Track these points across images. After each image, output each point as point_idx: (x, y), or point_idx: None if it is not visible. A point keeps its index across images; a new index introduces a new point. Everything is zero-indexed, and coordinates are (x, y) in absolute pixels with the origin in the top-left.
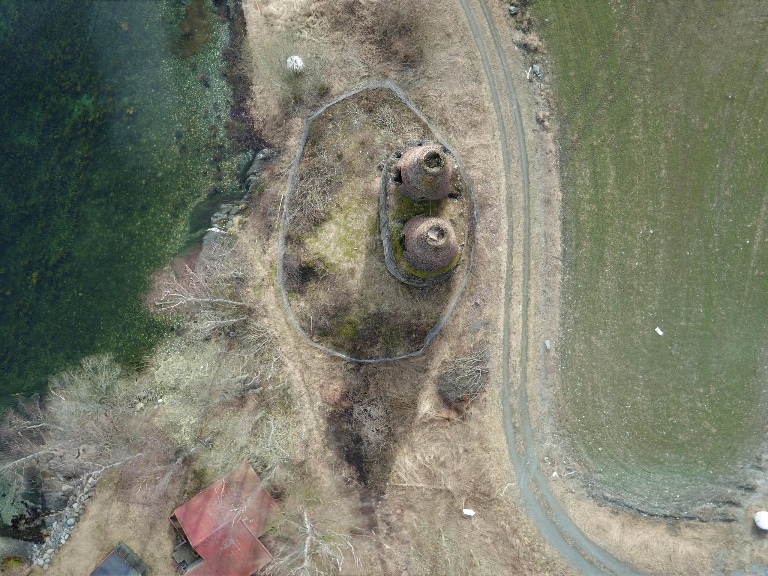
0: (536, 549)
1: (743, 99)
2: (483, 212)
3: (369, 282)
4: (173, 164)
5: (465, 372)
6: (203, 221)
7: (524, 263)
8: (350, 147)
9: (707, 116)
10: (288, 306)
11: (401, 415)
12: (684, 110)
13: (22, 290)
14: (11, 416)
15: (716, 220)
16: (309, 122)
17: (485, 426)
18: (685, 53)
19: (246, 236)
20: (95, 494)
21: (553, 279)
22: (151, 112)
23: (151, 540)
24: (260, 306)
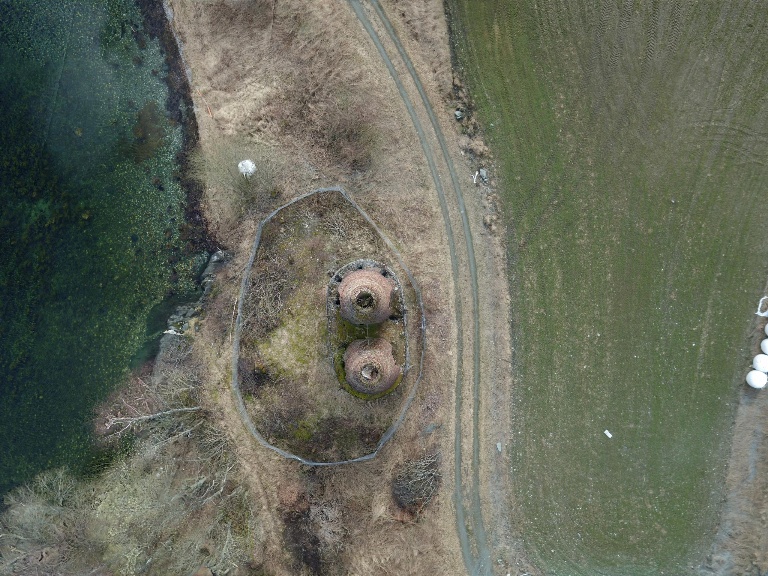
0: None
1: (686, 203)
2: (432, 317)
3: (322, 387)
4: (129, 267)
5: (418, 476)
6: (160, 323)
7: (474, 367)
8: (301, 253)
9: (651, 220)
10: (244, 409)
11: (357, 517)
12: (628, 214)
13: None
14: None
15: (662, 323)
16: (262, 225)
17: (438, 529)
18: (628, 158)
19: (202, 339)
20: None
21: (503, 382)
22: (107, 216)
23: None
24: (217, 409)
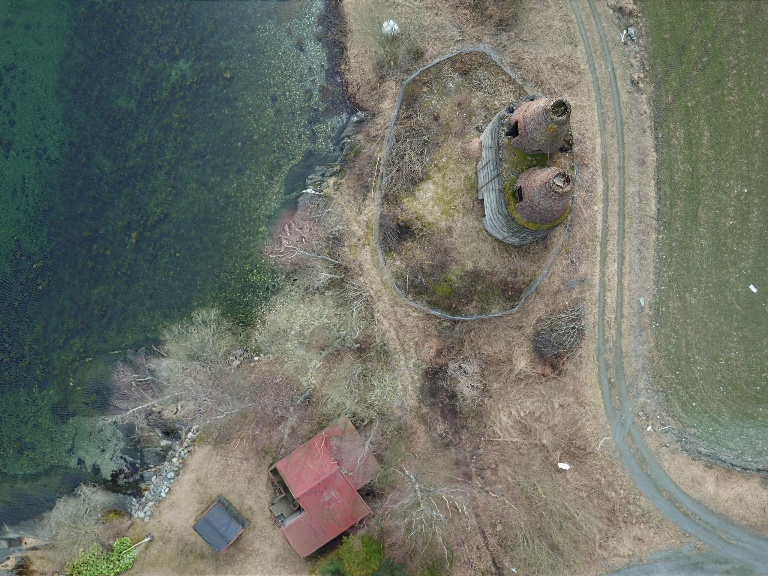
0: (631, 502)
1: None
2: (579, 172)
3: (466, 241)
4: (268, 127)
5: (561, 328)
6: (298, 183)
7: (619, 222)
8: (447, 109)
9: None
10: (384, 265)
11: (496, 371)
12: None
13: (120, 250)
14: (119, 369)
15: None
16: (403, 86)
17: (581, 381)
18: None
19: (341, 197)
20: (194, 449)
21: (647, 238)
22: (247, 76)
23: (249, 494)
24: (356, 265)
